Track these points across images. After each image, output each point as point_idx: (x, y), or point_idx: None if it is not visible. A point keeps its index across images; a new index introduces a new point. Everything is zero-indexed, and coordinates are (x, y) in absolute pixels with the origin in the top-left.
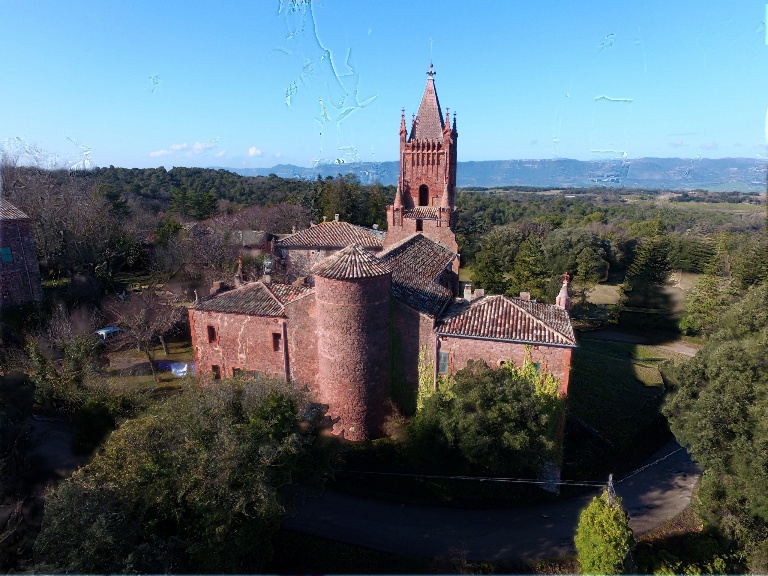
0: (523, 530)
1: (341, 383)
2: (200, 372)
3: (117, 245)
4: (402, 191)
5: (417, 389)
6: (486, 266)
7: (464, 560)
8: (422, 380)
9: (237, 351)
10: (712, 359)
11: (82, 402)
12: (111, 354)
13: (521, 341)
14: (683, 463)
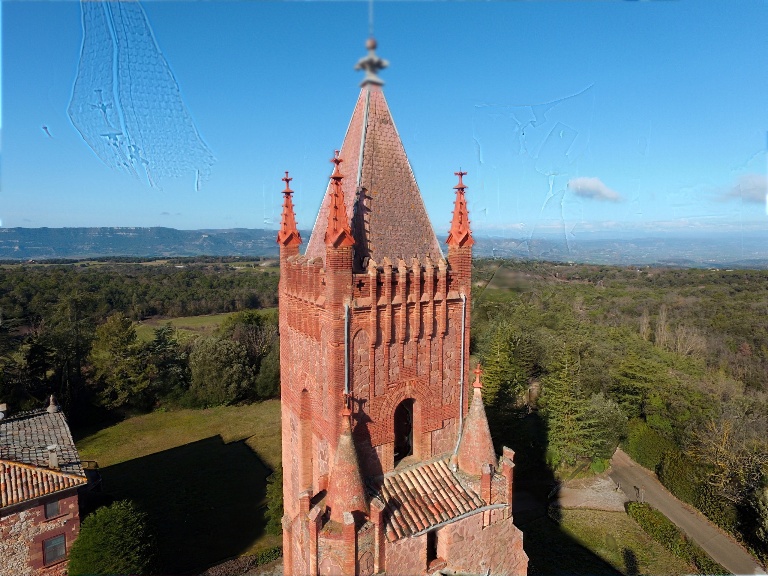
0: None
1: None
2: None
3: None
4: None
5: None
6: None
7: None
8: None
9: None
10: None
11: None
12: None
13: None
14: None
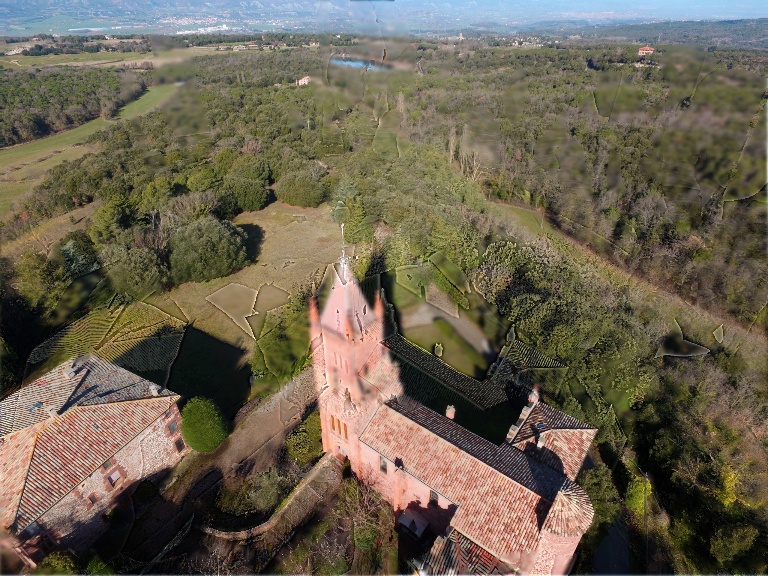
0: None
1: None
2: None
3: None
4: None
5: None
6: None
7: None
8: None
9: None
10: None
11: None
12: None
13: None
14: None
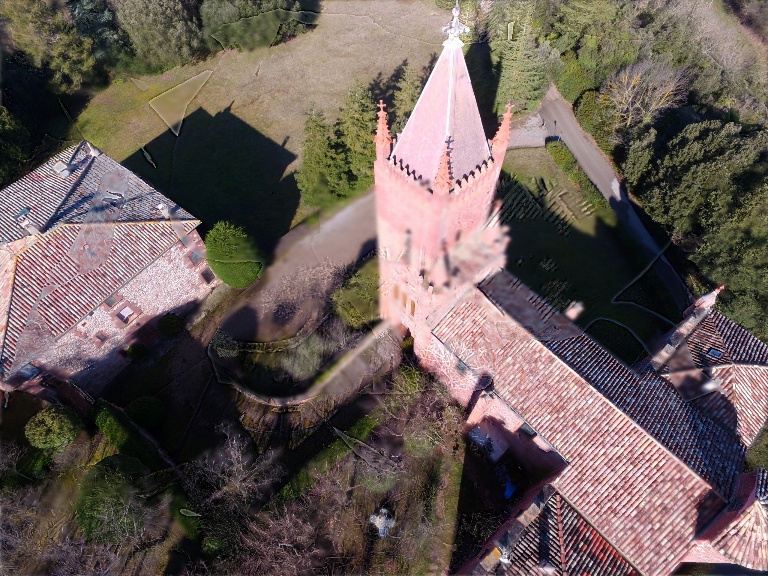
0: None
1: None
2: None
3: None
4: None
5: None
6: None
7: None
8: None
9: None
10: (748, 259)
11: None
12: None
13: None
14: (688, 305)
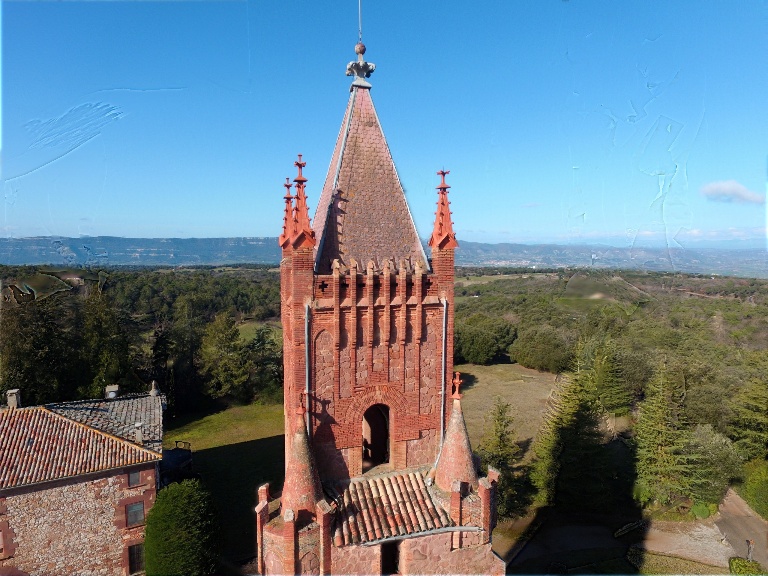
0: None
1: None
2: None
3: None
4: None
5: None
6: None
7: None
8: None
9: None
10: None
11: None
12: None
13: None
14: None
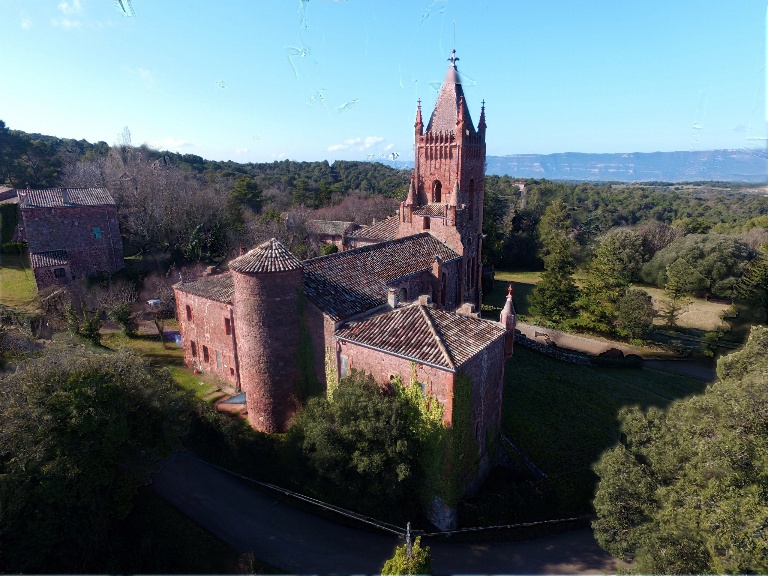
0: (373, 561)
1: (250, 373)
2: (184, 345)
3: (214, 229)
4: (417, 186)
5: (326, 391)
6: (553, 272)
7: (251, 569)
8: (329, 382)
9: (204, 330)
10: None
11: (3, 354)
12: (153, 321)
13: (404, 356)
14: None
